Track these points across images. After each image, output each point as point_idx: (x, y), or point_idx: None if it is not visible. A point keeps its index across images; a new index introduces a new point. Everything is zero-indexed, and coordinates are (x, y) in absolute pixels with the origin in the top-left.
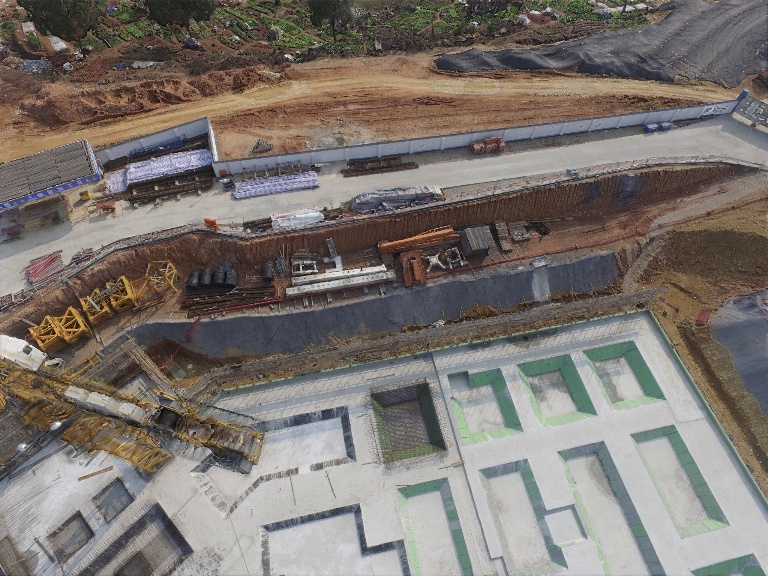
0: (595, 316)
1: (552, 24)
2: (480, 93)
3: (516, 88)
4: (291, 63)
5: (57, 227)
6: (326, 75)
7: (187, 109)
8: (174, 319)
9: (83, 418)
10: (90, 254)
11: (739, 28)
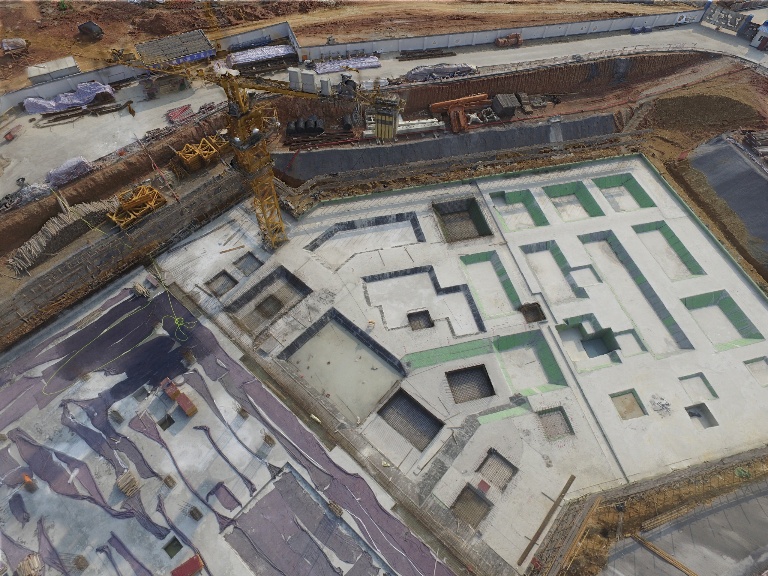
0: (600, 157)
1: None
2: (499, 12)
3: (527, 9)
4: None
5: (183, 92)
6: (373, 2)
7: (266, 23)
8: (280, 151)
9: (260, 147)
10: (213, 106)
11: None
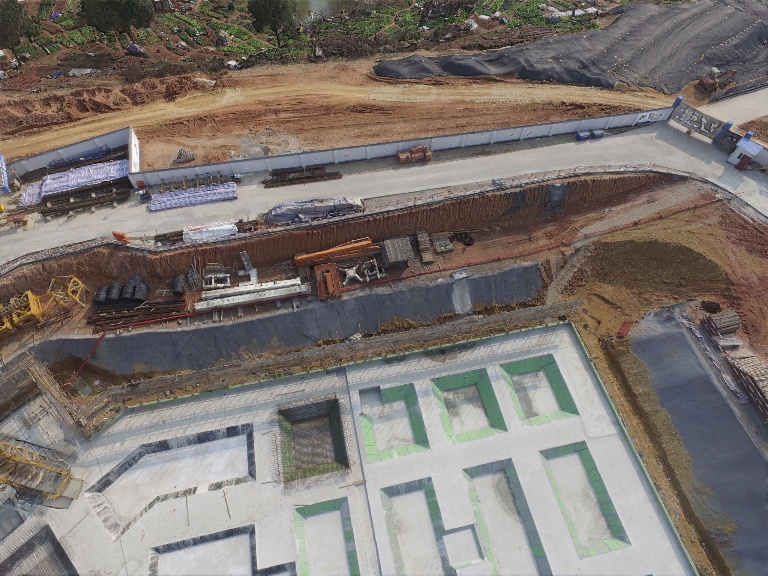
0: (515, 329)
1: (499, 29)
2: (416, 100)
3: (453, 95)
4: (229, 70)
5: None
6: (262, 82)
7: (115, 118)
8: (78, 335)
9: None
10: None
11: (687, 32)
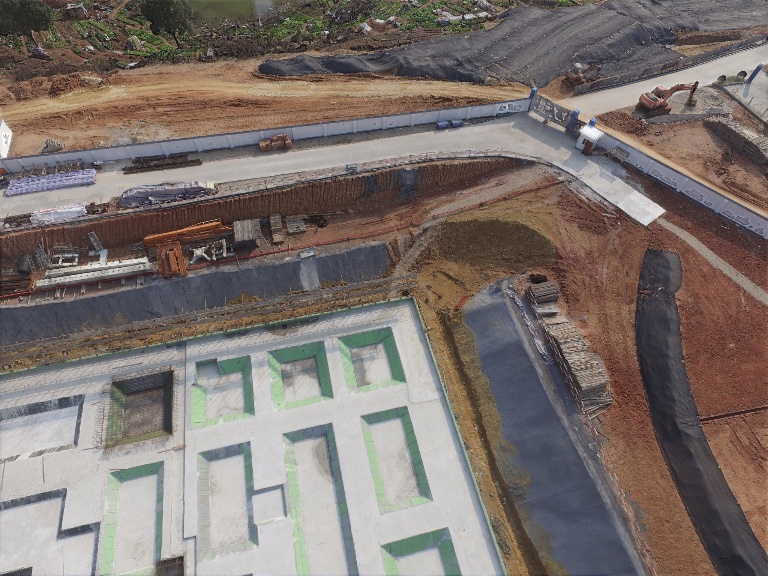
0: (358, 304)
1: (391, 32)
2: (293, 95)
3: (330, 90)
4: (119, 69)
5: None
6: (148, 80)
7: None
8: None
9: None
10: None
11: (565, 33)
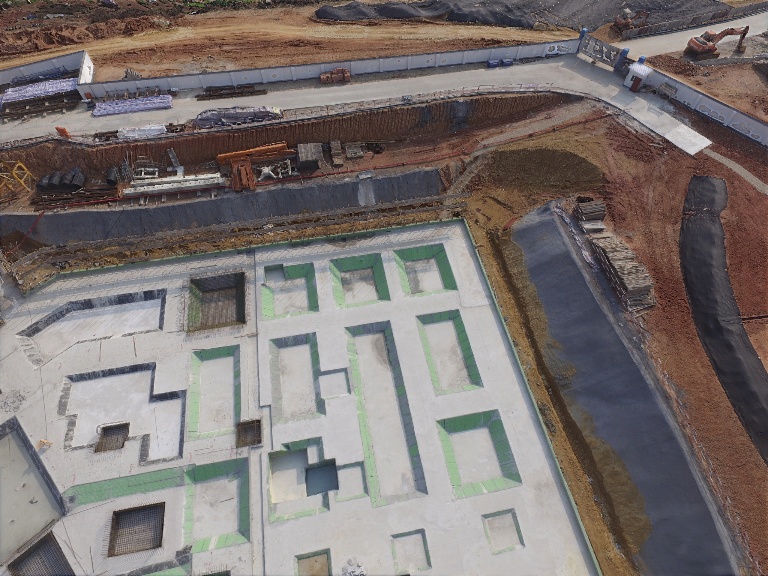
0: (412, 222)
1: None
2: (348, 37)
3: (383, 33)
4: (185, 14)
5: None
6: (212, 23)
7: (77, 49)
8: (22, 212)
9: None
10: None
11: None
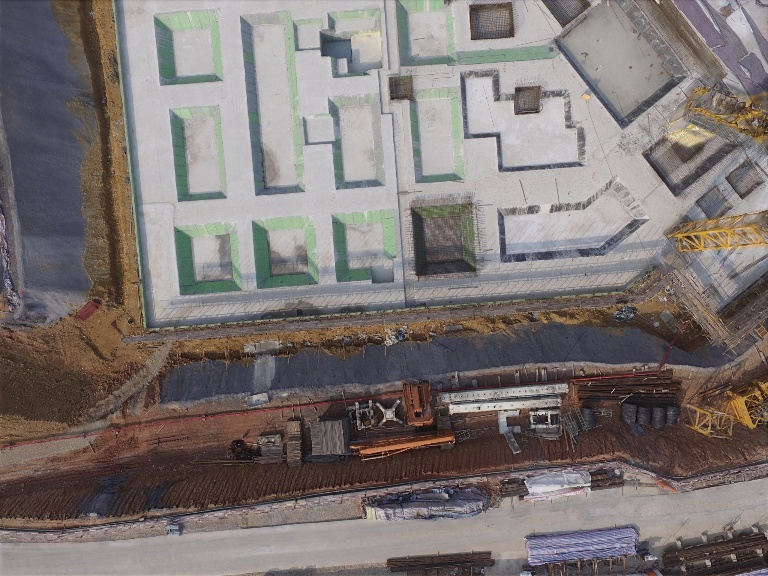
0: None
1: None
2: None
3: None
4: None
5: None
6: None
7: None
8: (687, 370)
9: None
10: None
11: None
